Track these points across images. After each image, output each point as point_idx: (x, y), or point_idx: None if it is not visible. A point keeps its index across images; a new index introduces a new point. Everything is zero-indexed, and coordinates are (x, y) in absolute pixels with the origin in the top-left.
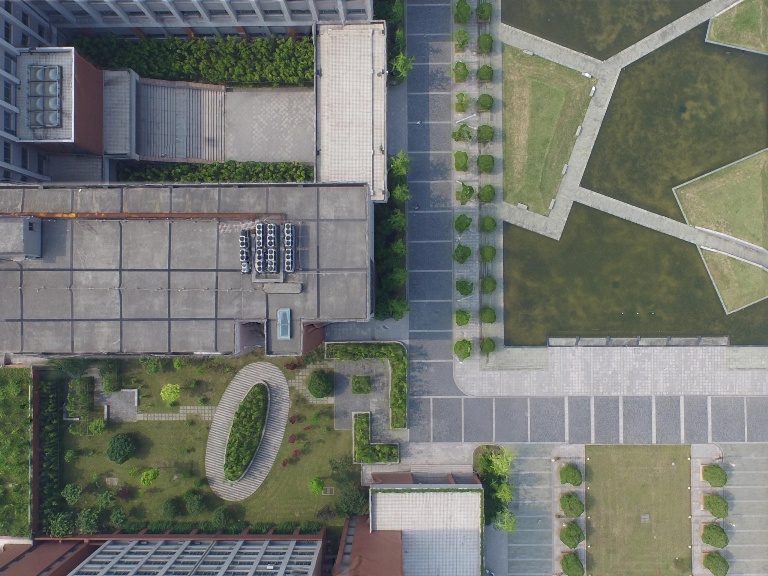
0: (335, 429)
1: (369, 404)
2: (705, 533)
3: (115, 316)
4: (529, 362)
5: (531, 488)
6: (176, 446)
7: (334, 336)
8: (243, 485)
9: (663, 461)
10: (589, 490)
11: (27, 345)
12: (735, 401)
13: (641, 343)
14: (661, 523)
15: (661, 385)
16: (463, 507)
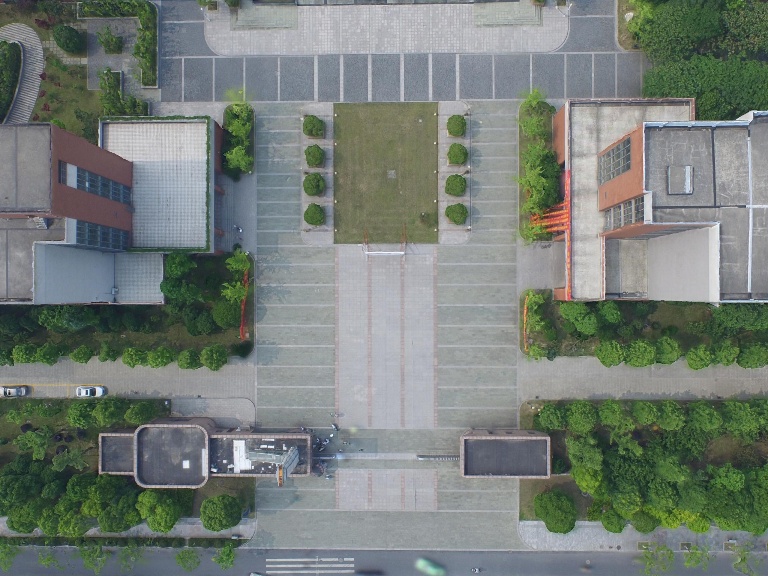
0: (88, 89)
1: (122, 64)
2: (446, 181)
3: None
4: (278, 20)
5: (280, 146)
6: None
7: None
8: None
9: (410, 118)
10: (337, 147)
11: None
12: (483, 59)
13: (389, 1)
14: (407, 179)
15: (409, 43)
16: (193, 139)
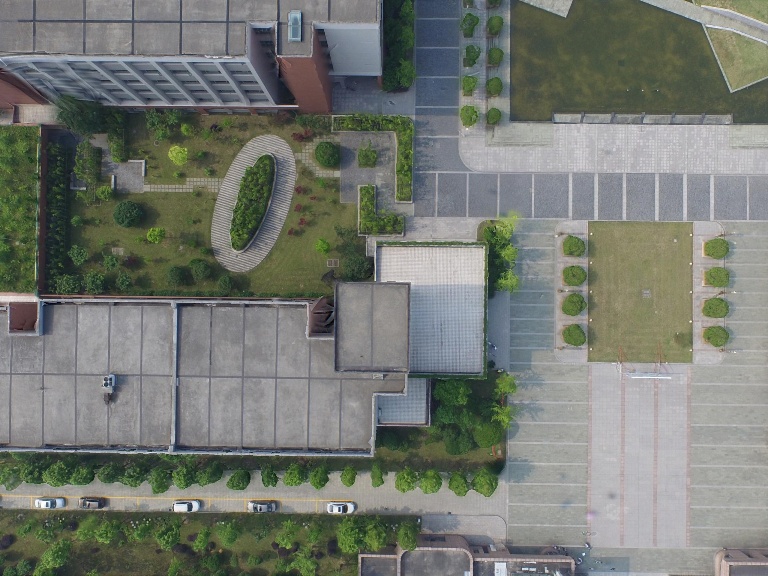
0: (341, 202)
1: (375, 178)
2: (706, 304)
3: (127, 18)
4: (534, 138)
5: (534, 263)
6: (182, 217)
7: (341, 110)
8: (248, 256)
9: (665, 238)
10: (592, 265)
11: (39, 46)
12: (738, 180)
13: (645, 121)
14: (662, 298)
15: (665, 163)
16: (467, 263)
